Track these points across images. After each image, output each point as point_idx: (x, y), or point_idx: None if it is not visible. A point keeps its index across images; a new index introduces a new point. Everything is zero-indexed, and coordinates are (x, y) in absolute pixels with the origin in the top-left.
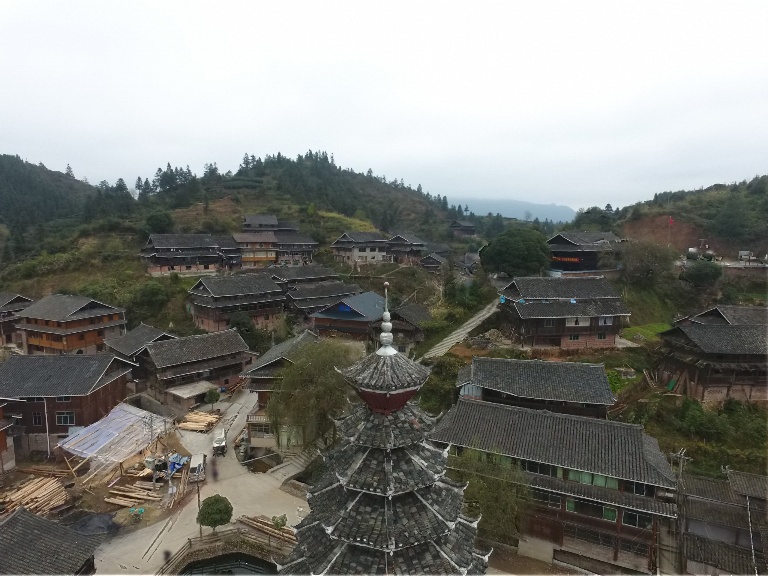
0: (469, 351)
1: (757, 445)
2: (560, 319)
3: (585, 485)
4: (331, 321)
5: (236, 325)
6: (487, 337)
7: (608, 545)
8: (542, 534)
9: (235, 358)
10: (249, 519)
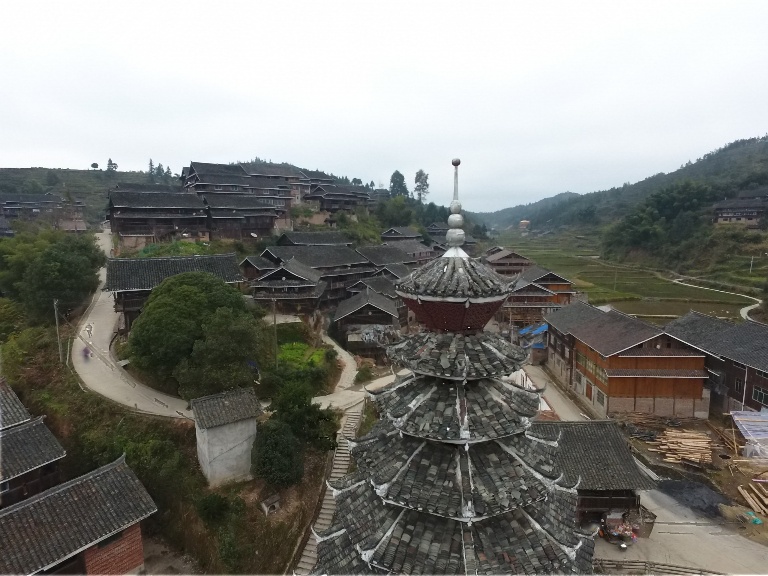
0: None
1: None
2: None
3: None
4: None
5: None
6: None
7: None
8: None
9: None
10: None
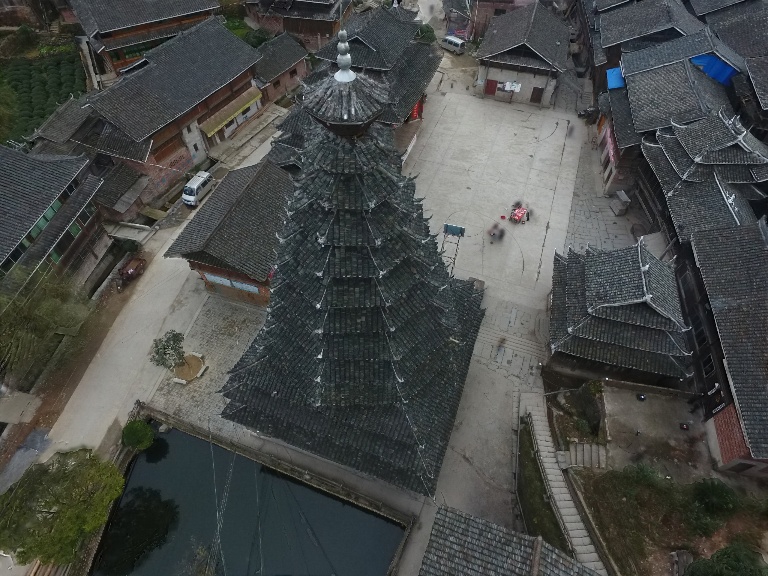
0: None
1: None
2: None
3: (47, 228)
4: None
5: None
6: None
7: None
8: None
9: None
10: None
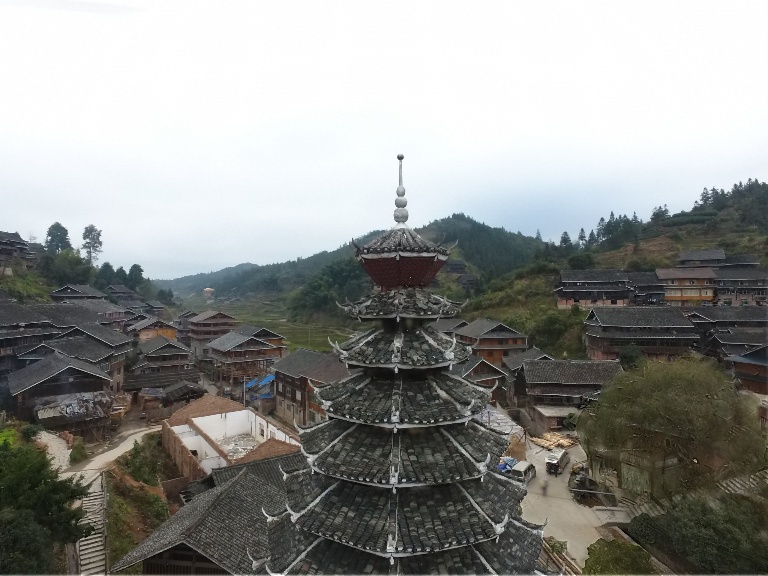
0: None
1: None
2: None
3: None
4: (761, 369)
5: (624, 358)
6: None
7: None
8: None
9: None
10: None
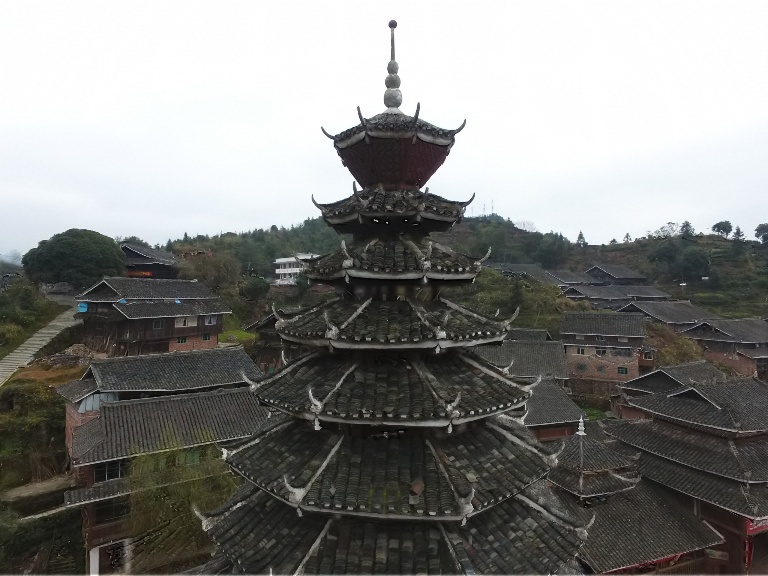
0: (50, 372)
1: None
2: (170, 319)
3: None
4: None
5: None
6: (69, 354)
7: None
8: None
9: None
10: None
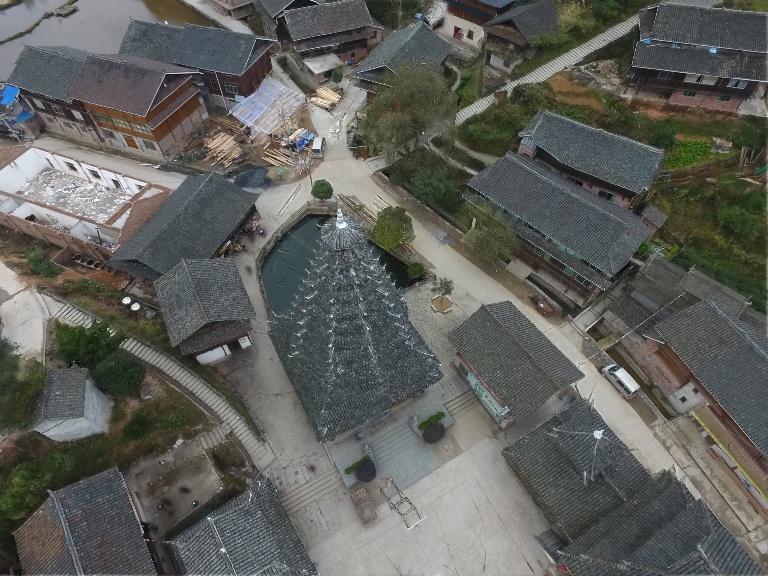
0: (567, 85)
1: (766, 254)
2: (679, 73)
3: (560, 250)
4: None
5: None
6: (598, 69)
7: (564, 284)
8: (528, 262)
9: (360, 33)
10: (344, 197)
